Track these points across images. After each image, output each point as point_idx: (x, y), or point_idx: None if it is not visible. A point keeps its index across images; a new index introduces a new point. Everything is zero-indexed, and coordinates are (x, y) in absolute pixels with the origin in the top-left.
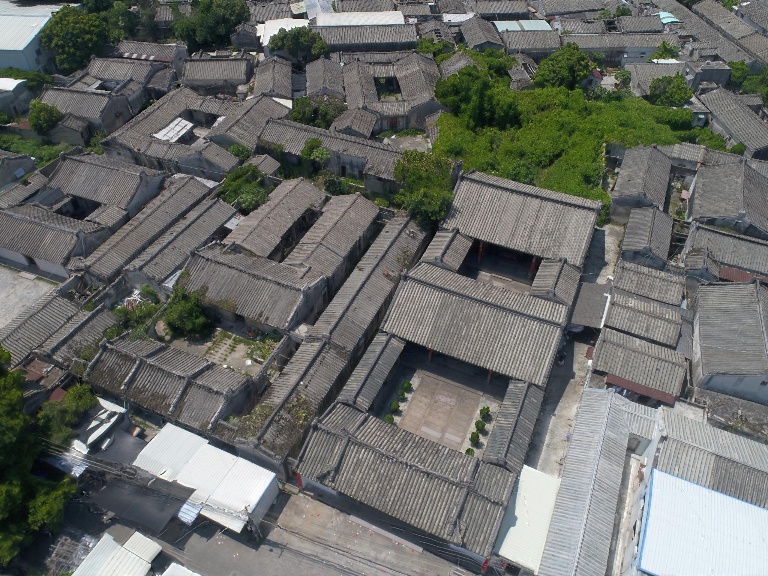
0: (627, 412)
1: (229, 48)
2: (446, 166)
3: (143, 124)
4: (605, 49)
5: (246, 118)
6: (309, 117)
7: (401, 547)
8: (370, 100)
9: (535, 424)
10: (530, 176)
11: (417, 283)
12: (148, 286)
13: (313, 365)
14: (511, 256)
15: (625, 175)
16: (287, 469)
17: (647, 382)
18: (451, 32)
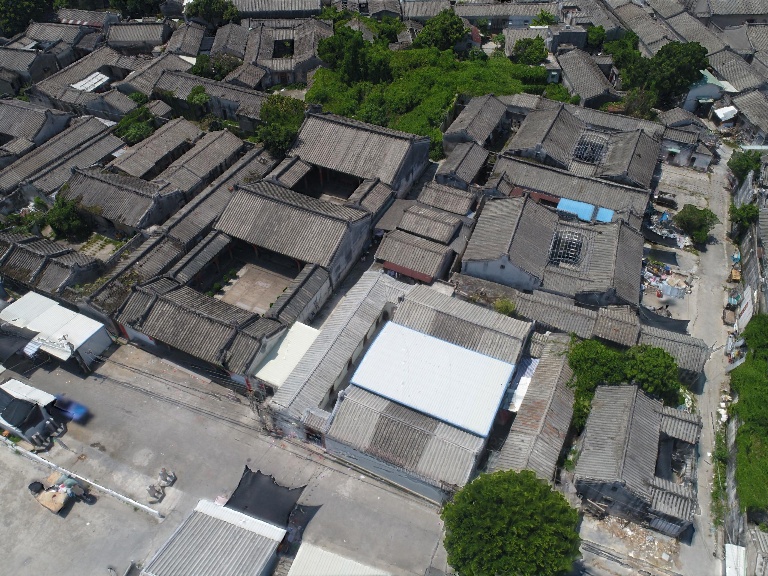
0: (389, 287)
1: (156, 16)
2: (301, 107)
3: (63, 76)
4: (491, 17)
5: (150, 71)
6: (207, 71)
7: (195, 379)
8: (263, 58)
9: (327, 301)
10: (382, 119)
11: (246, 192)
12: (39, 198)
13: (151, 251)
14: (349, 181)
15: (461, 118)
16: (117, 324)
17: (413, 267)
18: (359, 3)
